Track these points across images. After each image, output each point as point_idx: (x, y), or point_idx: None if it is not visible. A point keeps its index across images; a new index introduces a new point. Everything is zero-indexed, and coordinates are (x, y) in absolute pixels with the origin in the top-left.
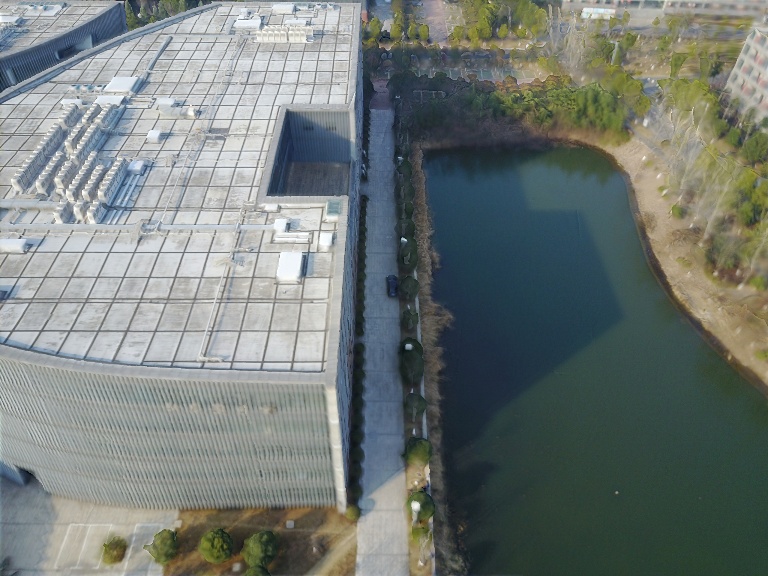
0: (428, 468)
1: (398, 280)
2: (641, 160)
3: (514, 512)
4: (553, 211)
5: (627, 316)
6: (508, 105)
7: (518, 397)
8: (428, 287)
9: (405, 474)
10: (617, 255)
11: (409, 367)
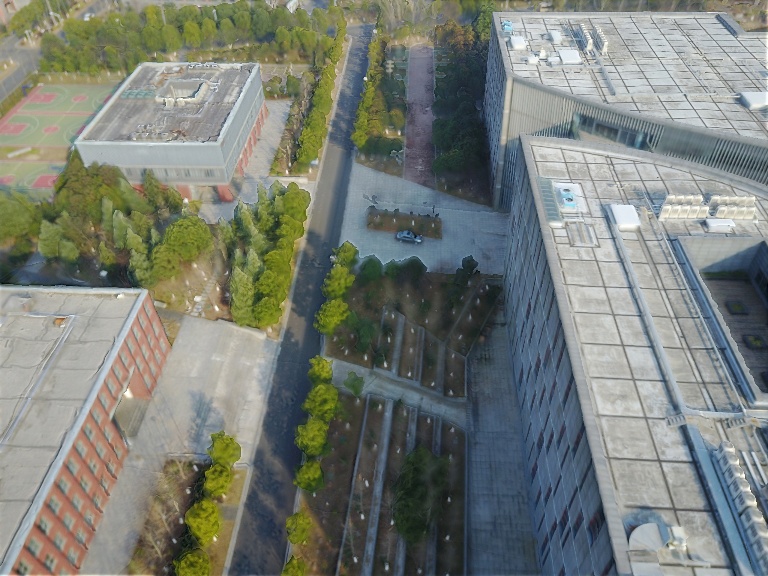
0: None
1: None
2: None
3: None
4: None
5: None
6: None
7: None
8: None
9: None
10: None
11: None
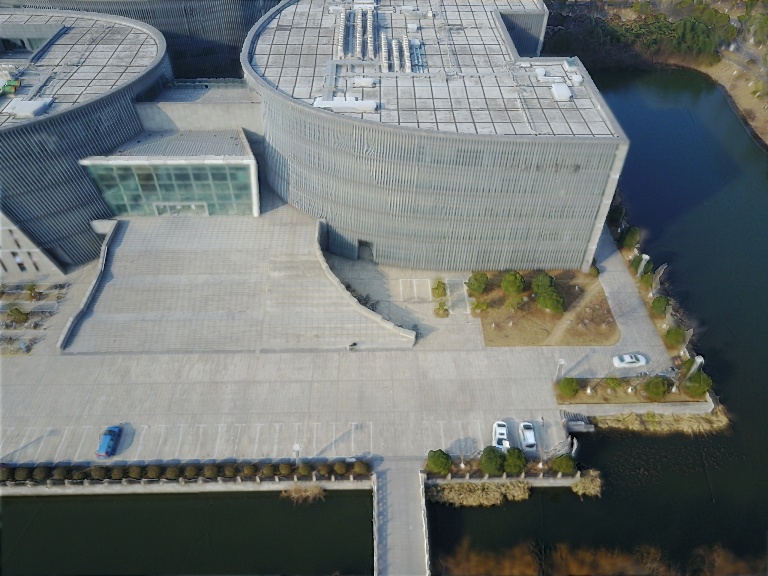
0: (636, 250)
1: None
2: (732, 75)
3: (700, 276)
4: (671, 109)
5: (747, 172)
6: (622, 33)
7: (682, 216)
8: None
9: (621, 253)
10: (727, 138)
11: None
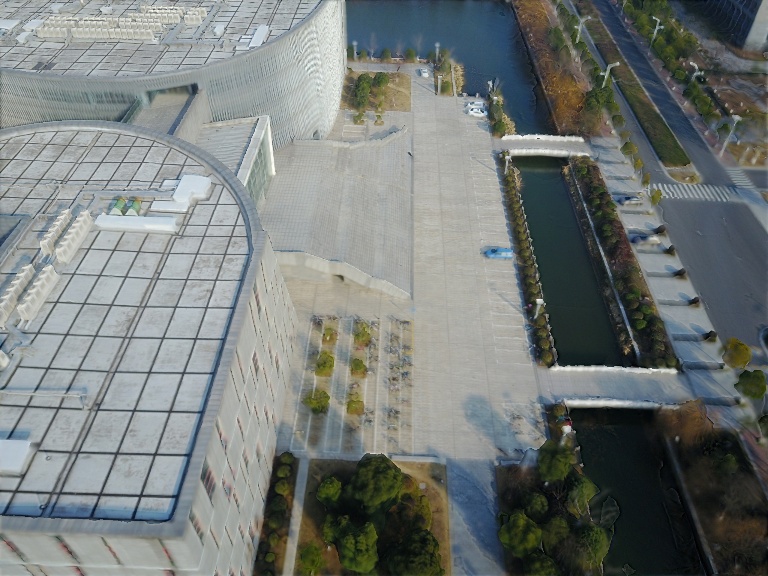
0: None
1: None
2: None
3: None
4: None
5: None
6: None
7: None
8: None
9: None
10: None
11: None
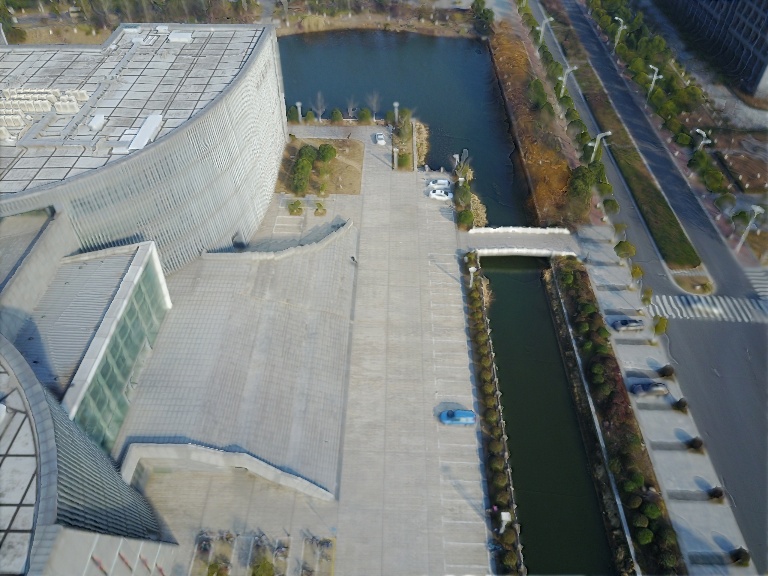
0: None
1: None
2: (50, 35)
3: None
4: None
5: None
6: None
7: None
8: None
9: None
10: None
11: None
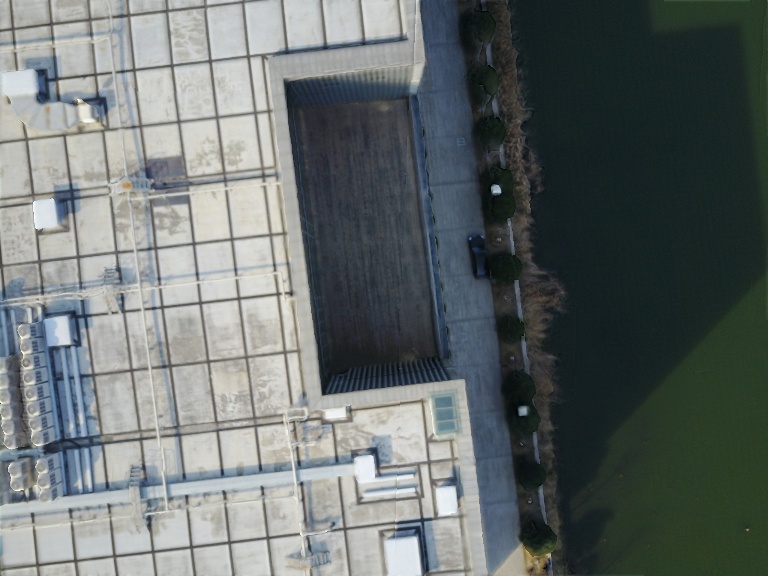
0: None
1: (486, 244)
2: None
3: (637, 564)
4: (724, 24)
5: None
6: None
7: (648, 418)
8: (526, 235)
9: (523, 551)
10: None
11: (523, 434)
